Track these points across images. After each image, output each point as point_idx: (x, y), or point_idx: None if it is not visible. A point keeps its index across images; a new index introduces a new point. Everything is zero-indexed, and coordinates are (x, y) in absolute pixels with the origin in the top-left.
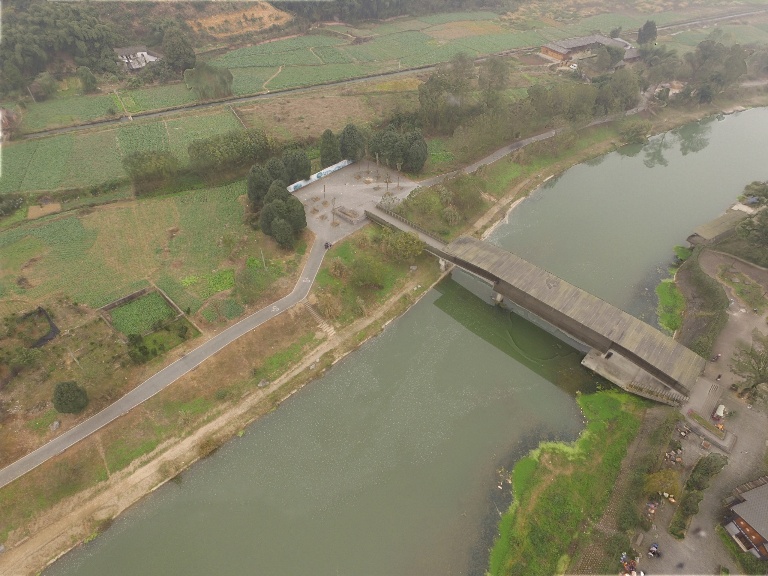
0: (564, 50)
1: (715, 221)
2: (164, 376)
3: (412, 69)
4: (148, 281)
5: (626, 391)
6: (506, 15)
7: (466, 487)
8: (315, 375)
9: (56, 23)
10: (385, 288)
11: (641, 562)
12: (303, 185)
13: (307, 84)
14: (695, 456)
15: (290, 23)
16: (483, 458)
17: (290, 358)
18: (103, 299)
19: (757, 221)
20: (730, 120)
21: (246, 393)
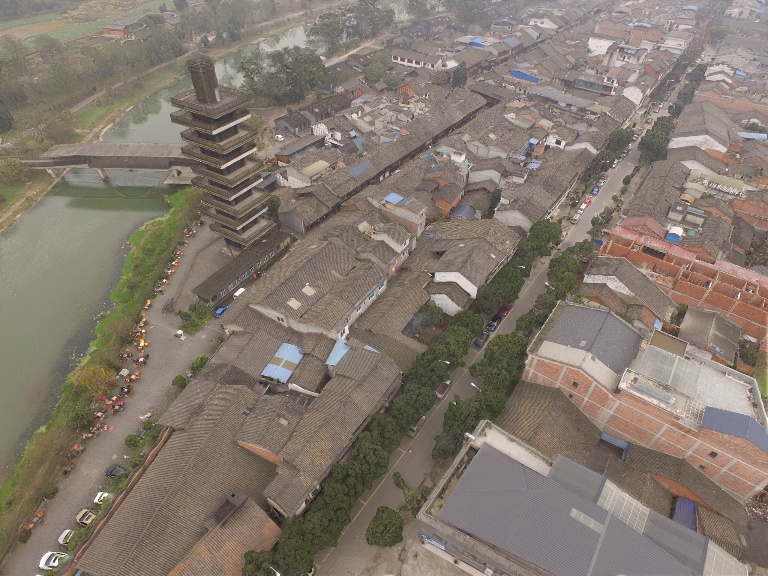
0: (121, 27)
1: None
2: None
3: None
4: None
5: None
6: (67, 13)
7: (102, 257)
8: None
9: None
10: (8, 200)
11: (195, 230)
12: None
13: None
14: None
15: None
16: (109, 242)
17: None
18: None
19: (245, 83)
20: None
21: None
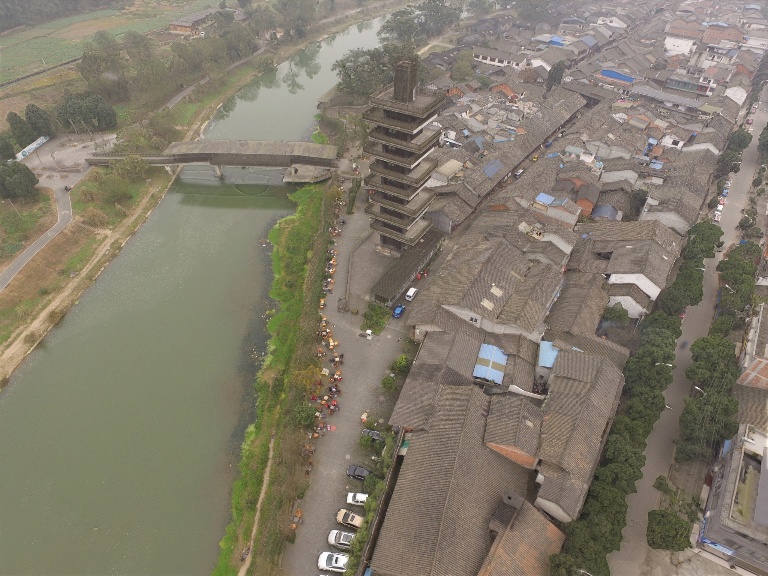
0: (188, 23)
1: (327, 93)
2: None
3: (60, 65)
4: None
5: (312, 183)
6: (125, 9)
7: (246, 255)
8: (112, 255)
9: None
10: (134, 197)
11: (339, 228)
12: None
13: None
14: (350, 187)
15: None
16: (249, 240)
17: (85, 255)
18: None
19: (342, 81)
20: (329, 50)
21: (64, 284)
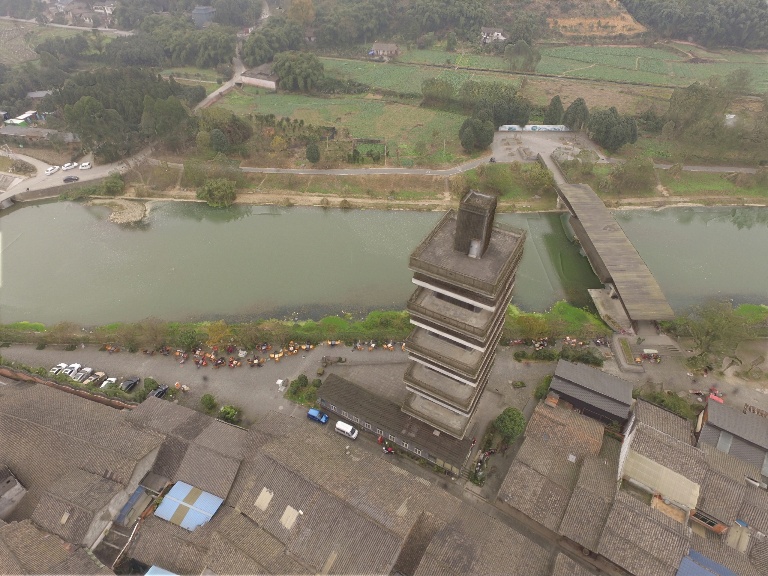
0: None
1: None
2: (353, 171)
3: None
4: (385, 138)
5: (602, 319)
6: None
7: None
8: (418, 209)
9: (455, 3)
10: (504, 196)
11: None
12: (517, 130)
13: (600, 78)
14: None
15: (637, 34)
16: None
17: (414, 196)
18: (360, 137)
19: None
20: None
21: (380, 197)
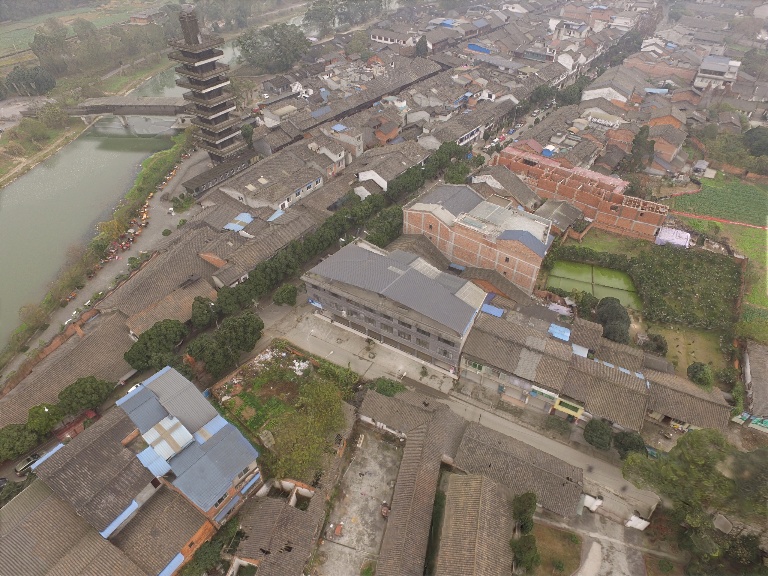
0: (145, 16)
1: (234, 66)
2: None
3: (28, 50)
4: None
5: None
6: (100, 7)
7: (120, 174)
8: (21, 173)
9: None
10: (51, 138)
11: None
12: None
13: None
14: None
15: None
16: (127, 165)
17: (1, 173)
18: None
19: (241, 54)
20: None
21: None
